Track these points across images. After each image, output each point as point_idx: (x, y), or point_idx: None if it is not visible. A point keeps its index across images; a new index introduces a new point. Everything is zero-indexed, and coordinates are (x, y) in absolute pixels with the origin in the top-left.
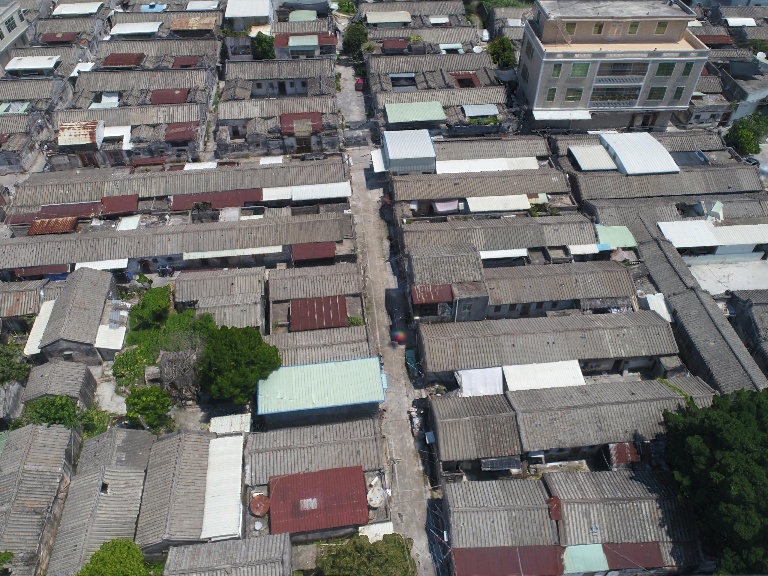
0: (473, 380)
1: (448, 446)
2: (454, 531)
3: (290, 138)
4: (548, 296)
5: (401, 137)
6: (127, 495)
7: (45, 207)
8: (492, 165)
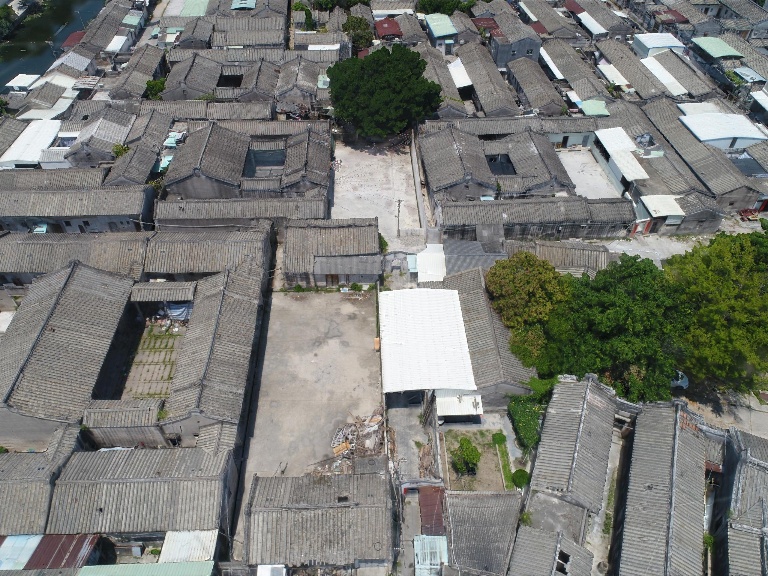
0: None
1: (414, 49)
2: (374, 46)
3: (653, 19)
4: None
5: (666, 37)
6: None
7: None
8: (664, 77)
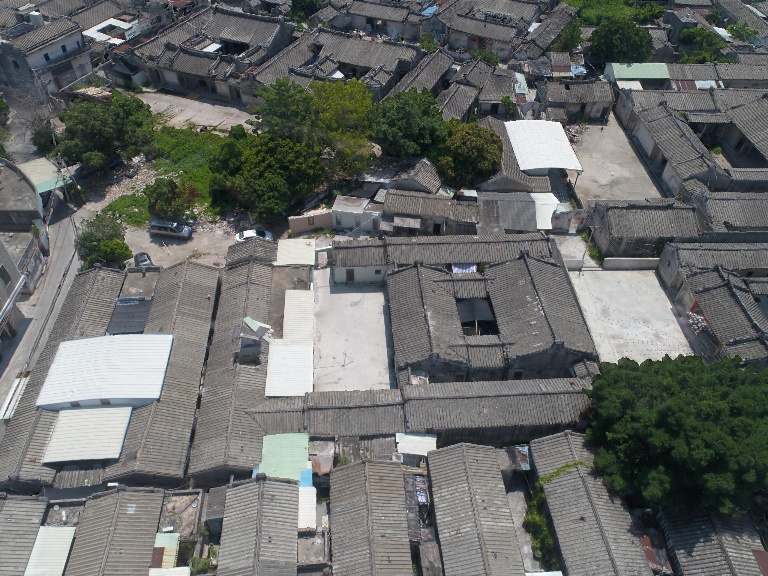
0: None
1: None
2: None
3: None
4: None
5: None
6: None
7: None
8: None
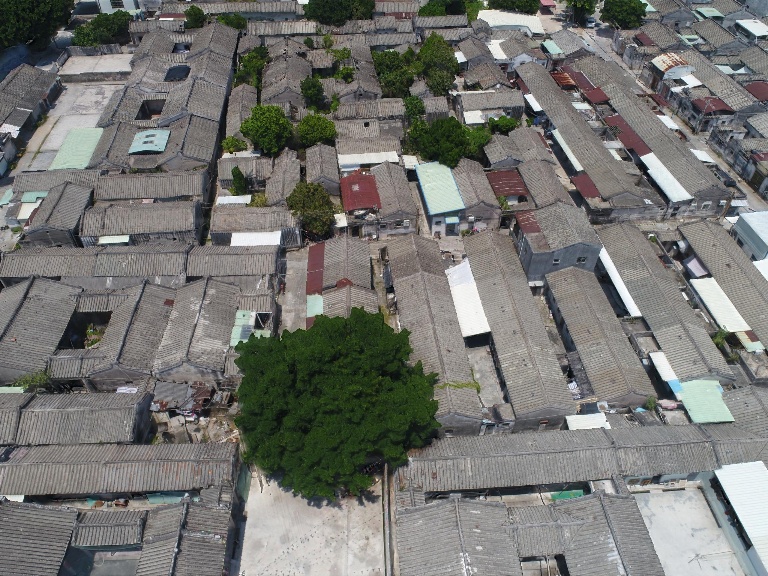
0: (462, 269)
1: (396, 244)
2: (334, 239)
3: (753, 165)
4: (571, 322)
5: None
6: (364, 134)
7: (580, 72)
8: None
